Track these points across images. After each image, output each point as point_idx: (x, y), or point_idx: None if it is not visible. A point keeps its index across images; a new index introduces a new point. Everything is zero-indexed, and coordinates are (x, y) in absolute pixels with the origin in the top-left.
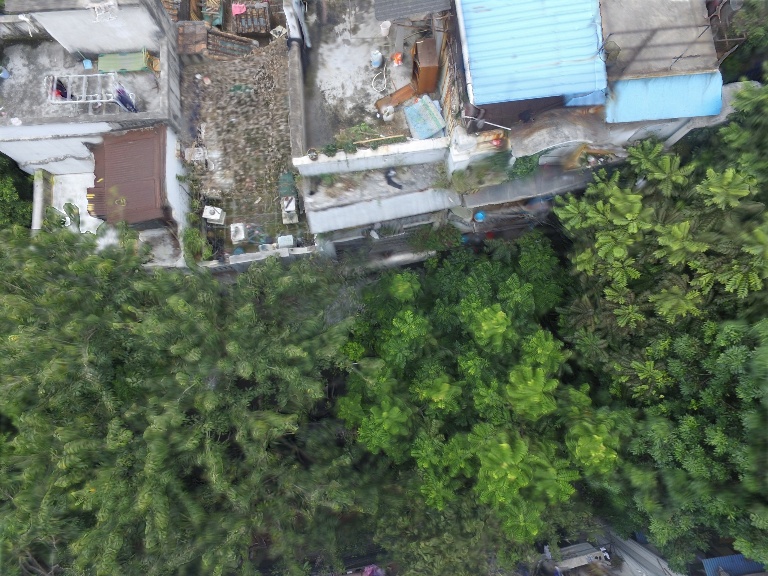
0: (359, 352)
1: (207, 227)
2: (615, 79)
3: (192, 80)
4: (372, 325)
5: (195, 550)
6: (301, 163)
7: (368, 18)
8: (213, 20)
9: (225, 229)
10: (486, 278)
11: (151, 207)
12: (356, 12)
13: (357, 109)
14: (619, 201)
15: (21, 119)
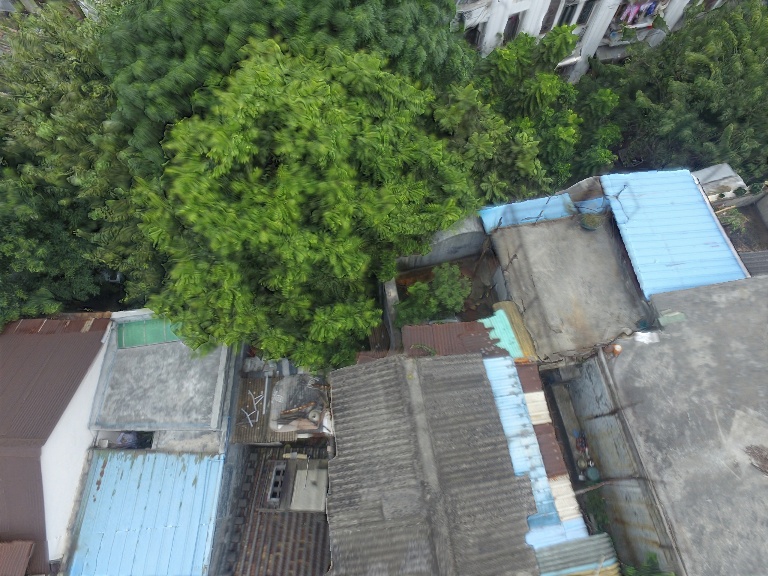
0: None
1: None
2: None
3: None
4: None
5: (704, 20)
6: None
7: None
8: None
9: None
10: None
11: None
12: None
13: None
14: (530, 164)
15: None
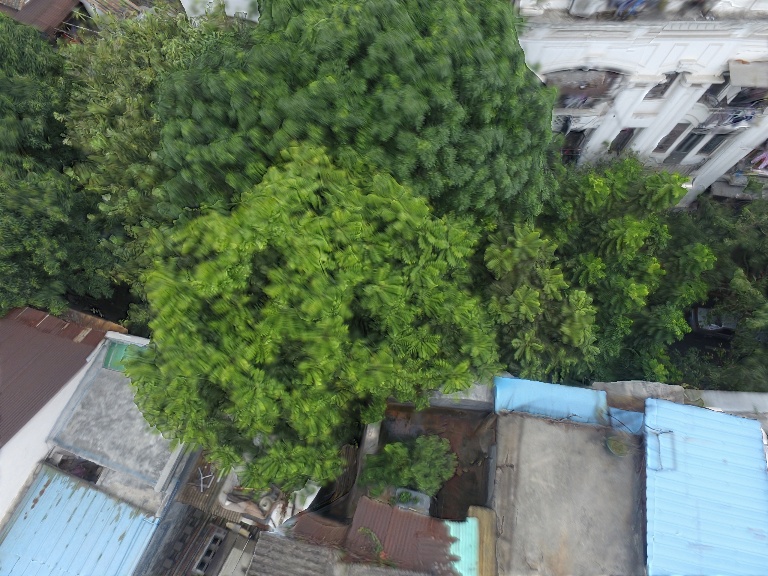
0: None
1: None
2: None
3: None
4: None
5: None
6: None
7: None
8: None
9: None
10: None
11: None
12: None
13: None
14: (578, 333)
15: None
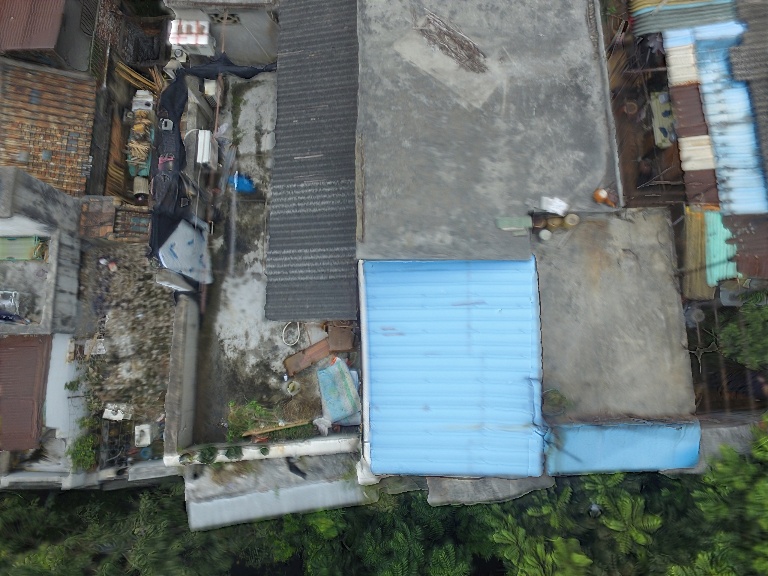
0: (286, 556)
1: (110, 424)
2: (562, 426)
3: (95, 265)
4: (300, 531)
5: None
6: (174, 464)
7: None
8: (139, 170)
9: (134, 421)
10: (420, 535)
11: (26, 435)
12: None
13: (261, 367)
14: (563, 561)
15: None
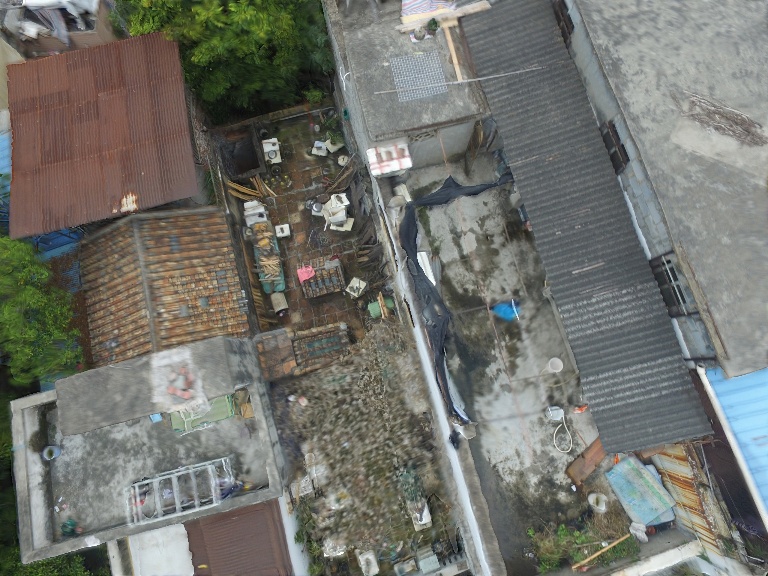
0: None
1: (328, 559)
2: None
3: (285, 404)
4: None
5: None
6: None
7: (524, 348)
8: (275, 286)
9: None
10: None
11: None
12: (507, 343)
13: (544, 483)
14: None
15: (98, 536)
